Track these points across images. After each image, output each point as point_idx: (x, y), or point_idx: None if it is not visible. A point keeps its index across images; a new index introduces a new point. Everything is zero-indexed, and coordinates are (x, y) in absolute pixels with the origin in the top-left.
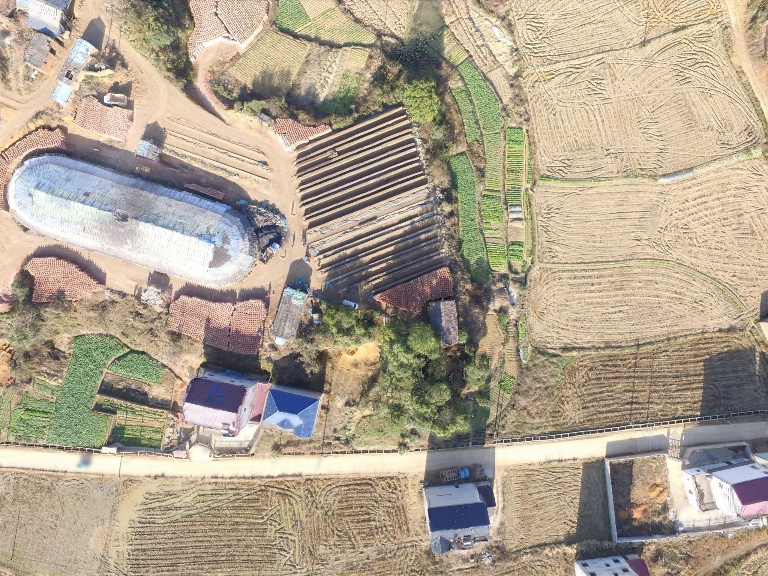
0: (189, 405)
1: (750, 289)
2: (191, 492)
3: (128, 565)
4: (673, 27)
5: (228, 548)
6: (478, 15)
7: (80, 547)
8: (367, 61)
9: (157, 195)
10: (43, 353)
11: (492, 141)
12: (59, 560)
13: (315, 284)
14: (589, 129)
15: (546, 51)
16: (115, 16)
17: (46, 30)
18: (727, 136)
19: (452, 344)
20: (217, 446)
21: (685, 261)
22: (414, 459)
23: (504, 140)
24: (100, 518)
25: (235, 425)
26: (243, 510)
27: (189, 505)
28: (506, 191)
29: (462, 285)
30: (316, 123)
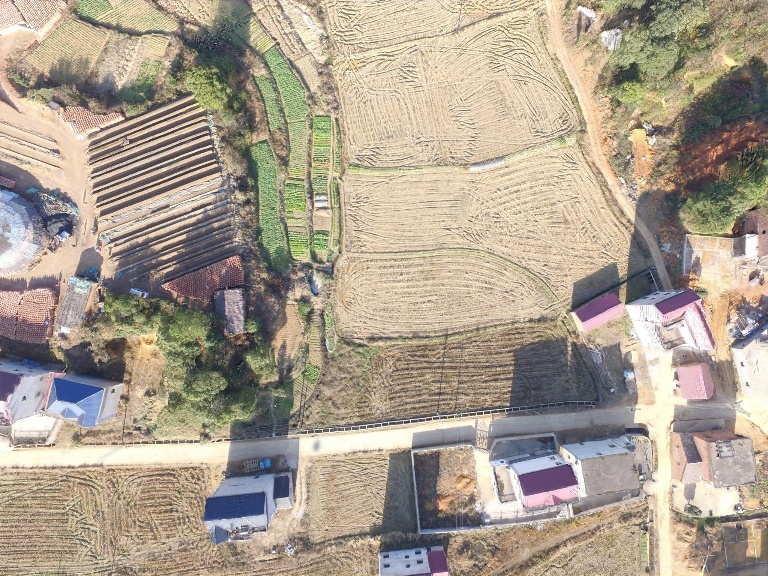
0: None
1: (562, 279)
2: None
3: None
4: (488, 14)
5: (29, 538)
6: (288, 2)
7: None
8: (166, 49)
9: None
10: None
11: (297, 129)
12: None
13: (106, 273)
14: (400, 117)
15: (357, 39)
16: None
17: None
18: (541, 124)
19: (236, 333)
20: (17, 436)
21: (496, 250)
22: (217, 450)
23: (309, 128)
24: None
25: (9, 414)
26: (44, 500)
27: None
28: (312, 180)
29: (257, 274)
30: (106, 111)
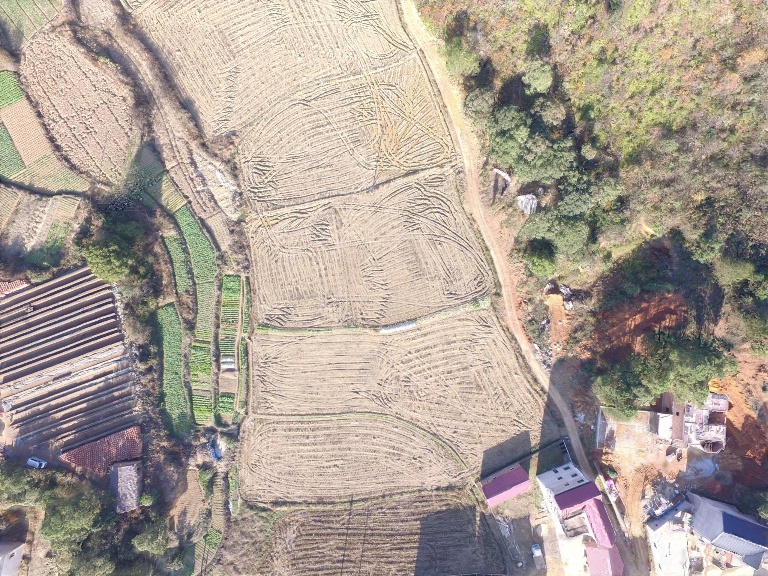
0: None
1: (472, 446)
2: None
3: None
4: (404, 171)
5: None
6: (202, 159)
7: None
8: (76, 211)
9: None
10: None
11: (205, 290)
12: None
13: (7, 439)
14: (311, 276)
15: (271, 195)
16: None
17: None
18: (455, 286)
19: (128, 510)
20: None
21: (405, 415)
22: None
23: (217, 289)
24: None
25: None
26: None
27: None
28: (219, 341)
29: (156, 443)
30: (11, 278)
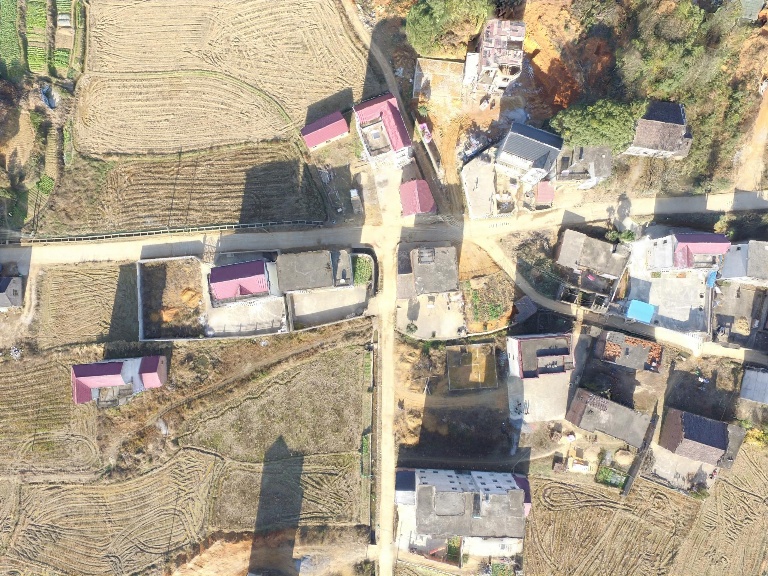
0: None
1: (297, 102)
2: None
3: None
4: None
5: None
6: None
7: None
8: None
9: None
10: None
11: None
12: None
13: None
14: None
15: None
16: None
17: None
18: None
19: None
20: None
21: (233, 73)
22: None
23: None
24: None
25: None
26: None
27: None
28: (57, 0)
29: None
30: None
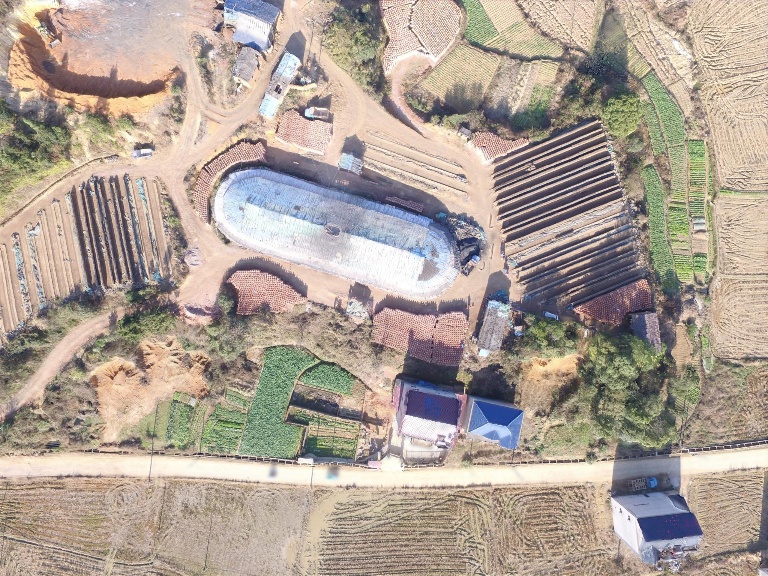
0: (408, 417)
1: None
2: (381, 502)
3: (320, 575)
4: None
5: (419, 557)
6: (658, 28)
7: (272, 557)
8: (557, 74)
9: (365, 208)
10: (238, 365)
11: (677, 154)
12: (251, 570)
13: (514, 296)
14: (767, 141)
15: (724, 64)
16: (316, 30)
17: (253, 44)
18: None
19: (656, 356)
20: (408, 456)
21: None
22: (601, 469)
23: (688, 153)
24: (291, 528)
25: (451, 437)
26: (433, 520)
27: (379, 515)
28: (689, 203)
29: (656, 297)
30: (515, 136)
